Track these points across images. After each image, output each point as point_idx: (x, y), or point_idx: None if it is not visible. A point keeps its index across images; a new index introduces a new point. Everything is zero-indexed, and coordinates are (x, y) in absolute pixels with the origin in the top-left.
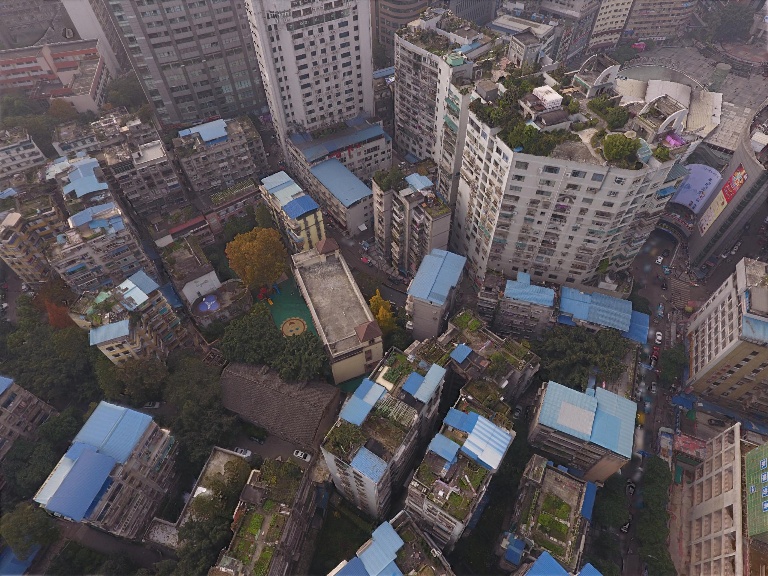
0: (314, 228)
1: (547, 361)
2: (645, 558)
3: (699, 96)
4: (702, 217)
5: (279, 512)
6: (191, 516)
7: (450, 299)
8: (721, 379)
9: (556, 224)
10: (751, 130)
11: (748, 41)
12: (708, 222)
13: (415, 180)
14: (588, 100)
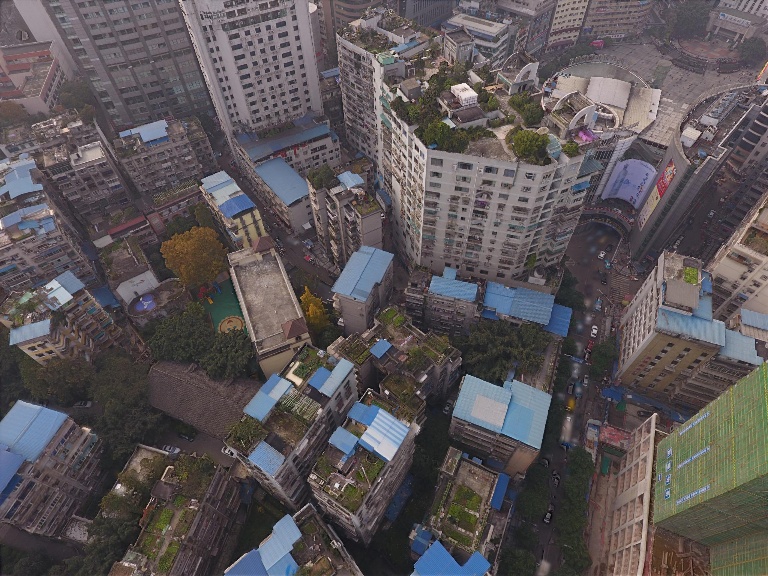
0: (252, 227)
1: (472, 355)
2: (562, 548)
3: (639, 92)
4: (641, 212)
5: (189, 507)
6: (101, 512)
7: (378, 295)
8: (645, 371)
9: (479, 220)
10: (684, 125)
11: (705, 38)
12: (645, 217)
13: (347, 178)
14: (510, 97)
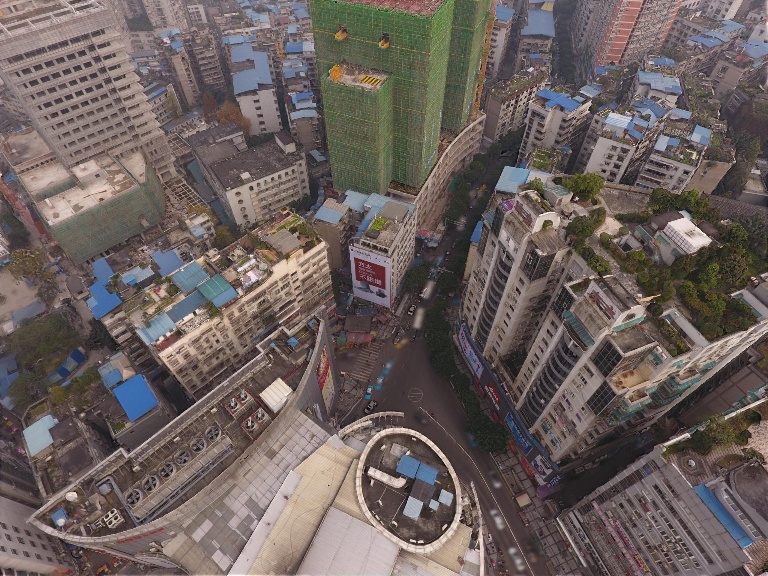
0: None
1: None
2: None
3: None
4: None
5: None
6: None
7: None
8: None
9: None
10: None
11: None
12: None
13: None
14: None
